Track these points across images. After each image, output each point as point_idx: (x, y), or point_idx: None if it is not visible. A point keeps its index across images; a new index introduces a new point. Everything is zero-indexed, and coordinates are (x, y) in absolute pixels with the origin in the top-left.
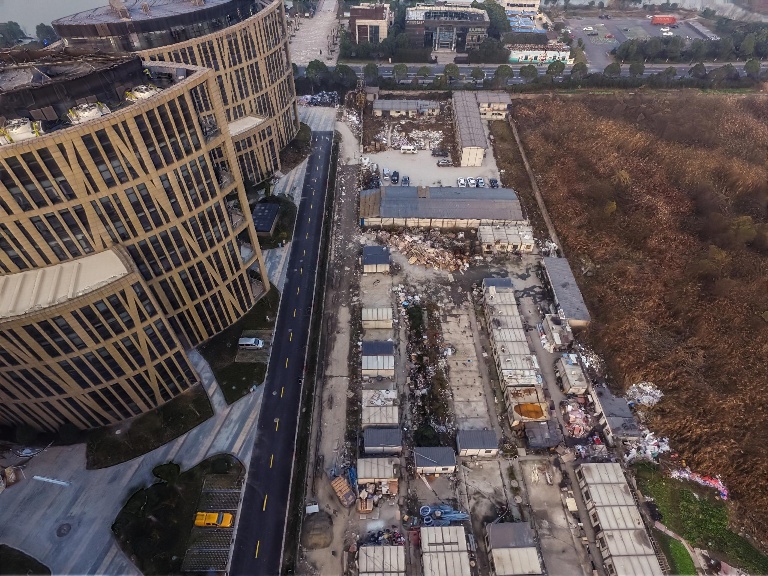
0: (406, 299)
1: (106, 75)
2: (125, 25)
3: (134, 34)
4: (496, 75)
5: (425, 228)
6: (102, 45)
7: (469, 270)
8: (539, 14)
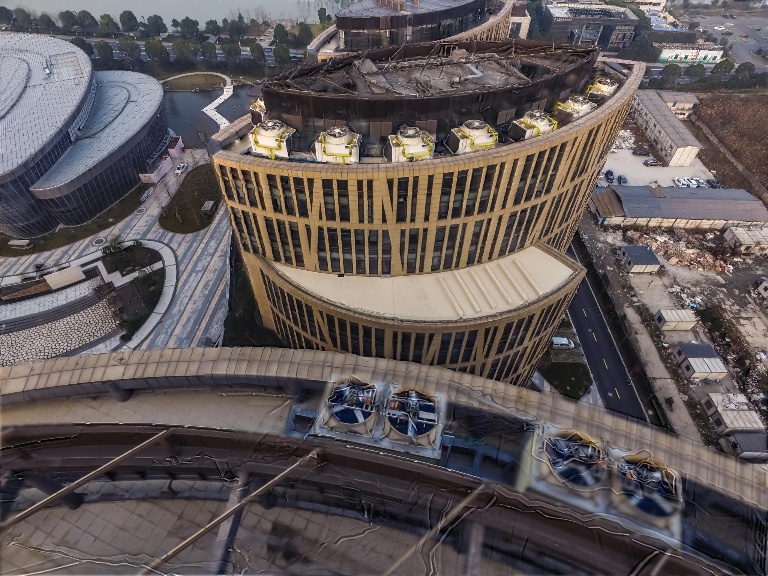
0: (692, 301)
1: (584, 68)
2: (406, 18)
3: (410, 27)
4: (664, 74)
5: (667, 228)
6: (378, 38)
7: (735, 272)
8: (663, 13)
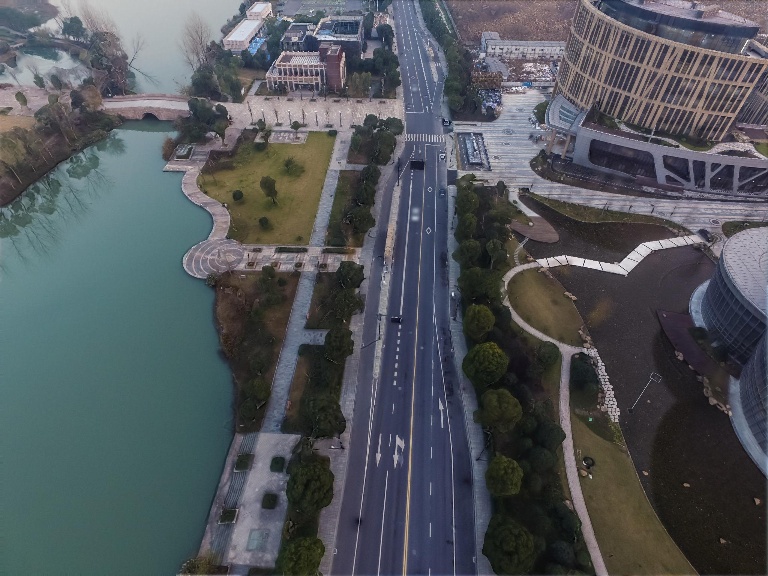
0: None
1: None
2: None
3: None
4: None
5: None
6: None
7: None
8: None
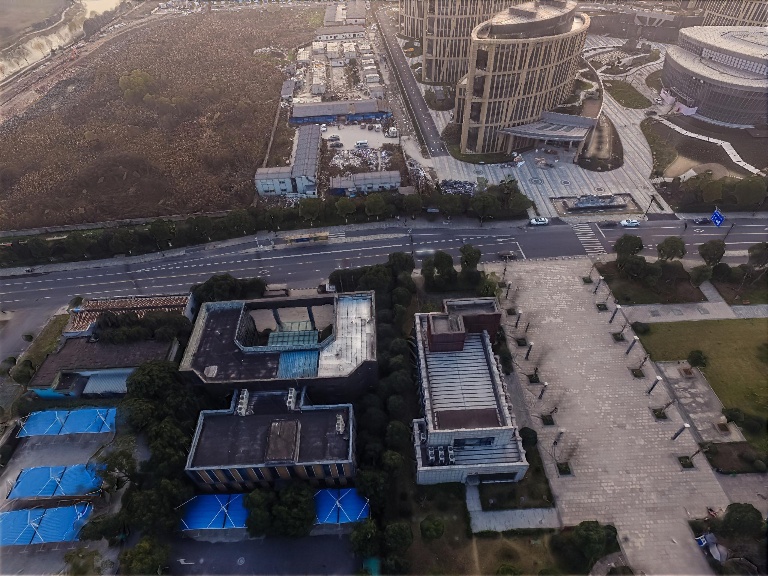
0: None
1: None
2: None
3: None
4: None
5: None
6: None
7: None
8: None
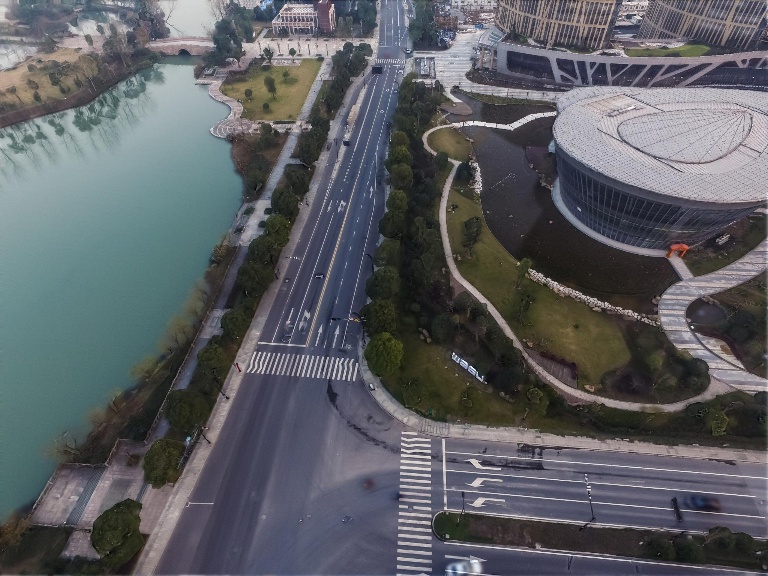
0: None
1: None
2: None
3: None
4: None
5: None
6: None
7: None
8: None
